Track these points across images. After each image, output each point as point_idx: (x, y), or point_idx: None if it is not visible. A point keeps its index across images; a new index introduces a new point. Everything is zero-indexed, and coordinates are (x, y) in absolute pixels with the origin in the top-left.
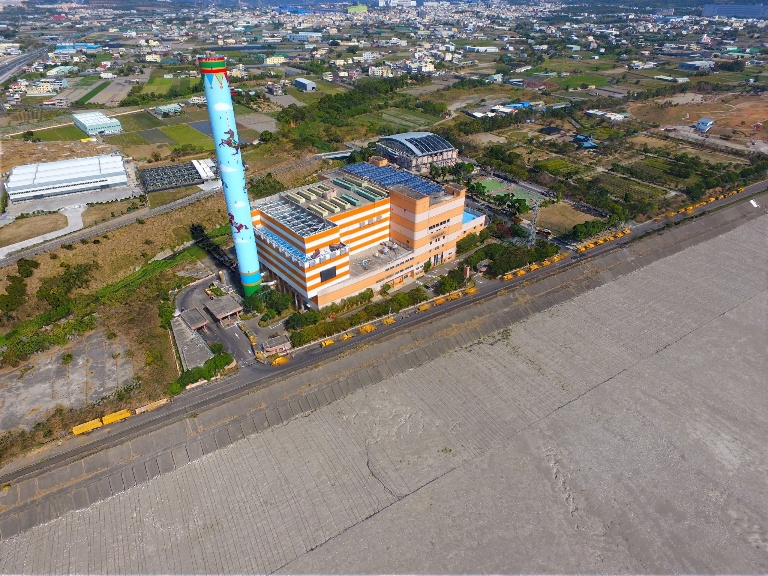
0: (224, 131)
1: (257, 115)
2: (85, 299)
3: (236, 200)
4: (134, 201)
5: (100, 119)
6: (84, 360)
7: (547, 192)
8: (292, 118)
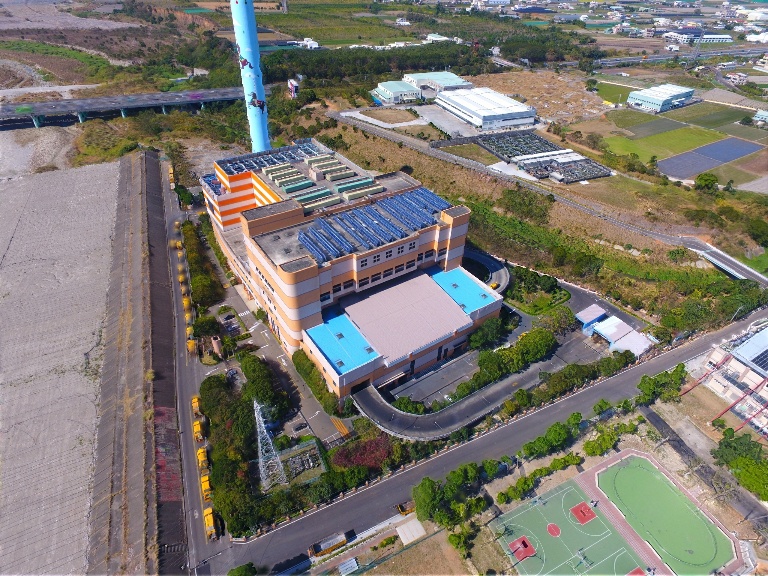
0: None
1: None
2: None
3: None
4: (442, 137)
5: (662, 93)
6: None
7: None
8: None
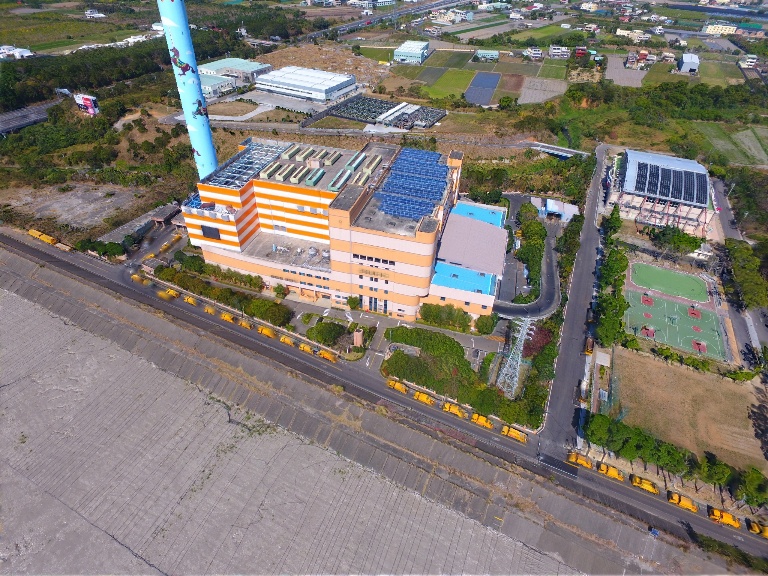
0: (170, 48)
1: (558, 82)
2: (187, 169)
3: (188, 122)
4: (302, 116)
5: (414, 48)
6: (110, 201)
7: None
8: (589, 96)
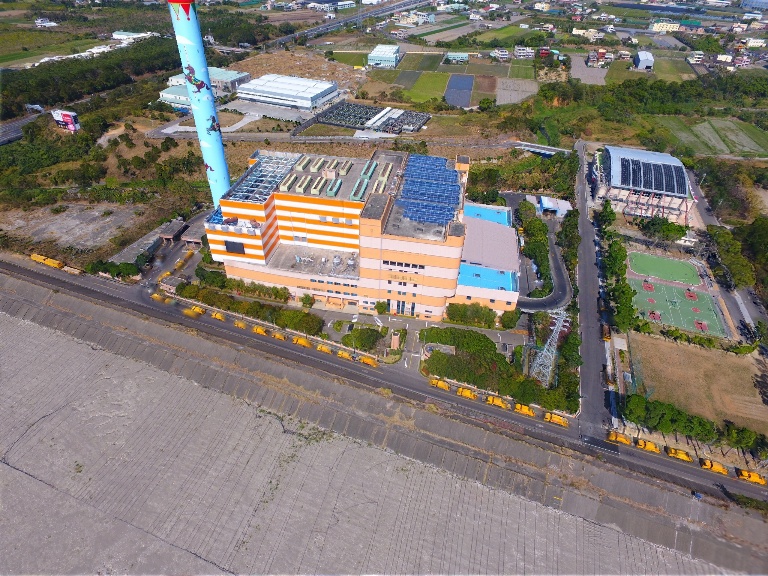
0: (185, 65)
1: (529, 82)
2: (181, 183)
3: (201, 139)
4: (291, 125)
5: (387, 52)
6: (109, 220)
7: (759, 330)
8: (559, 95)
